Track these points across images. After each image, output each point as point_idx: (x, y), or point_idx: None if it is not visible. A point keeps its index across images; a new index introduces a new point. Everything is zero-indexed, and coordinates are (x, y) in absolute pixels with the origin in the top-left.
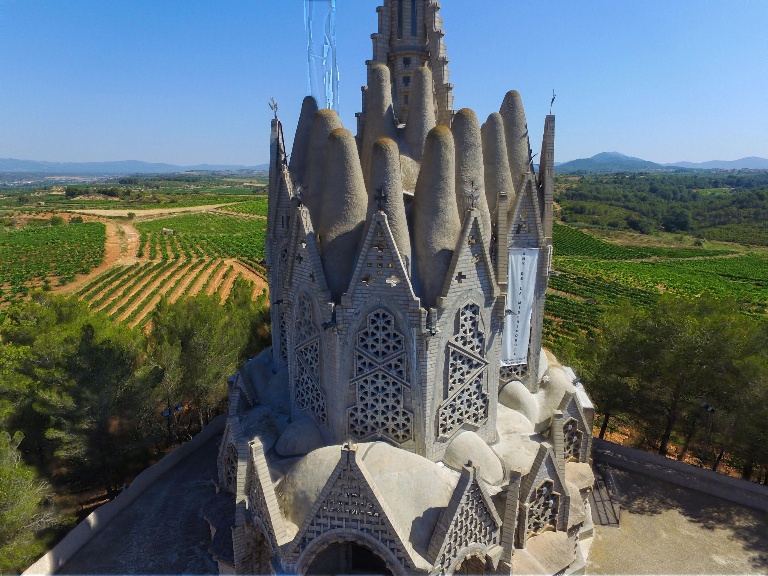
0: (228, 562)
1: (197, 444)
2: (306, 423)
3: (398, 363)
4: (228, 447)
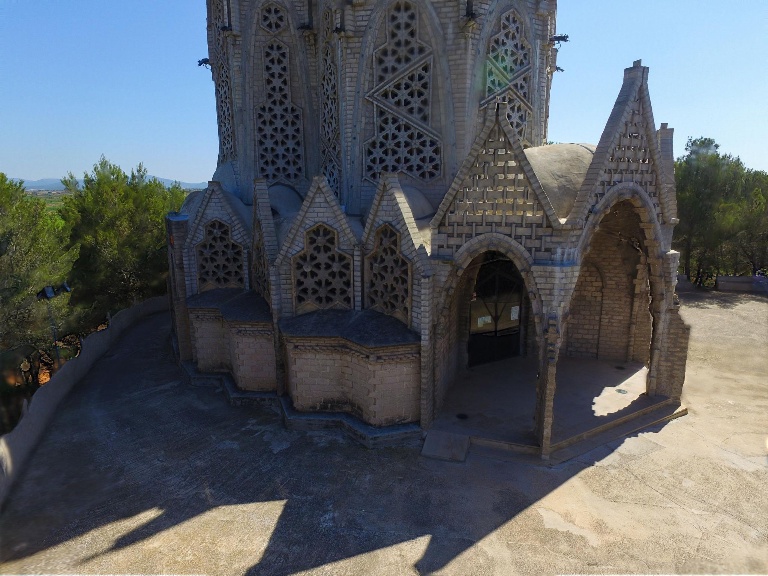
0: (398, 354)
1: (84, 366)
2: (406, 187)
3: (523, 83)
4: (308, 233)
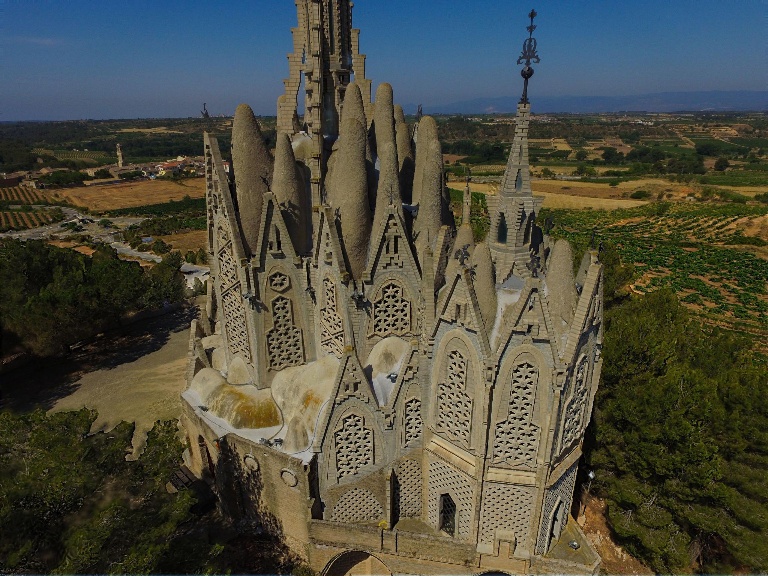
0: None
1: None
2: None
3: None
4: None
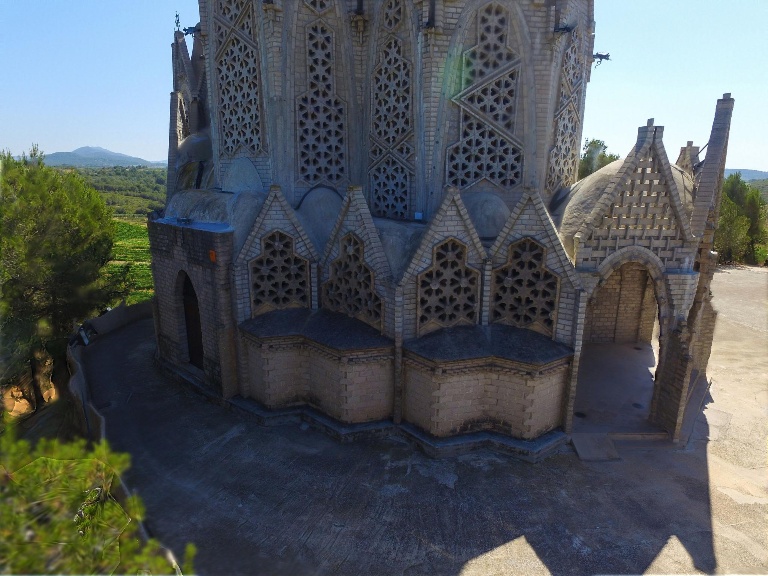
0: (553, 367)
1: None
2: (493, 195)
3: (576, 95)
4: (437, 248)
